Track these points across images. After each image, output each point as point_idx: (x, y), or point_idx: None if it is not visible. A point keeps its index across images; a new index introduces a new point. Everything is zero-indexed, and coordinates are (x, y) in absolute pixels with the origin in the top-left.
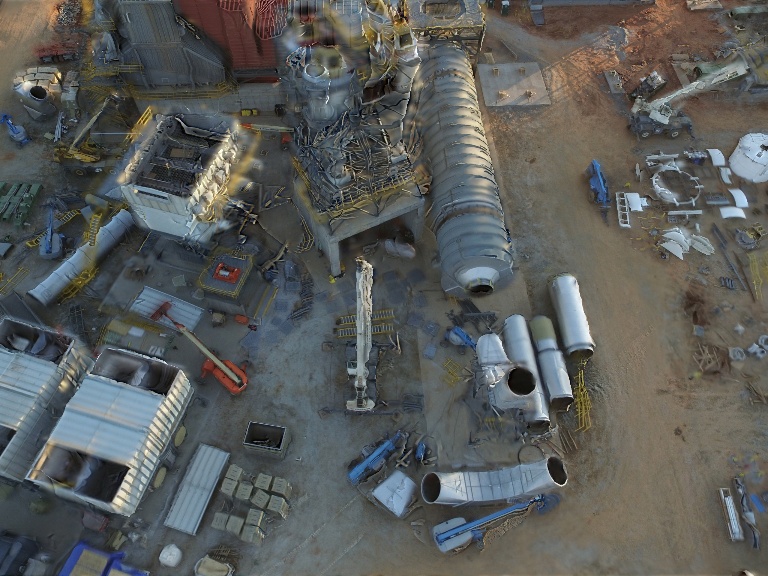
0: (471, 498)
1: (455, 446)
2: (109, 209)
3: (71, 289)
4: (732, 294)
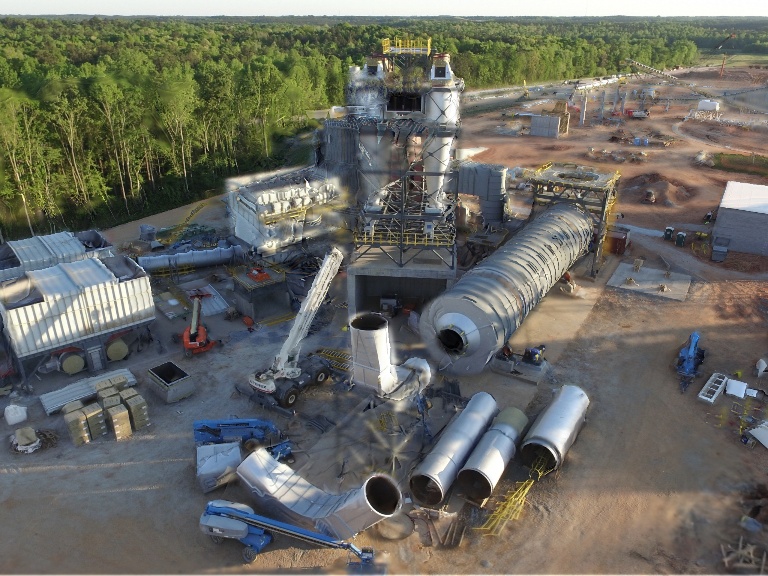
0: (278, 495)
1: (323, 473)
2: None
3: (165, 271)
4: None
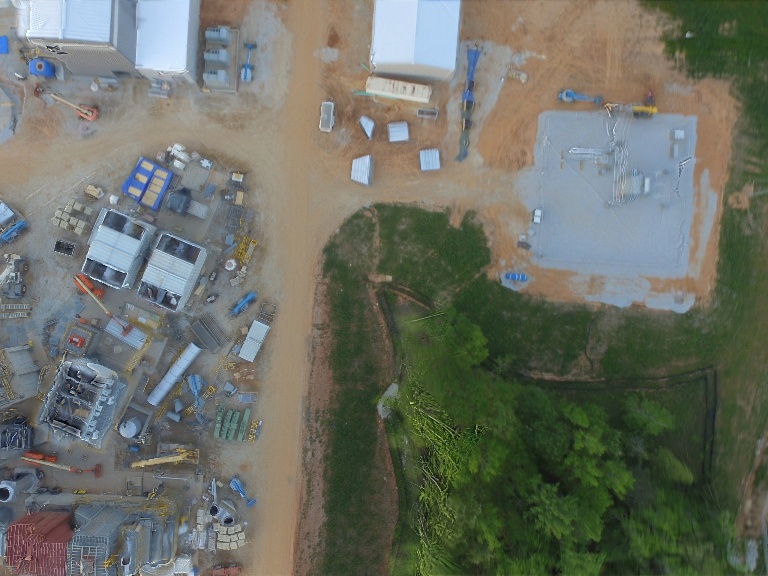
0: None
1: None
2: None
3: None
4: None
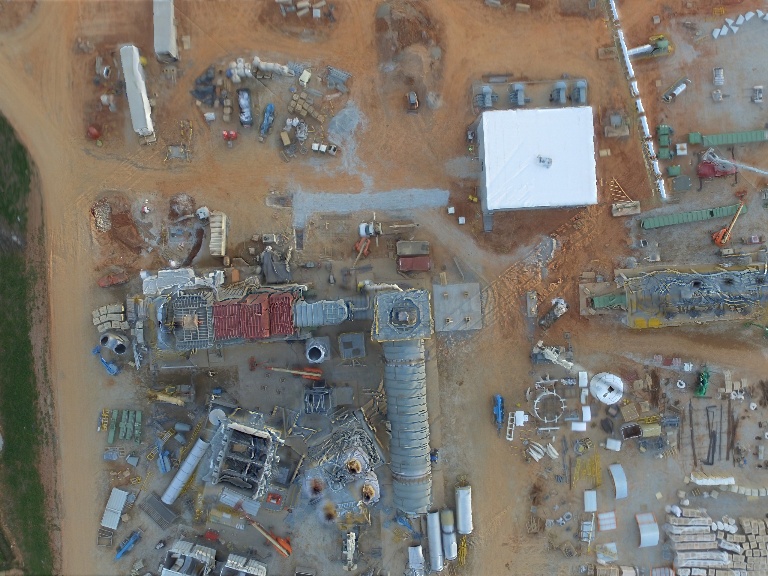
0: None
1: (397, 574)
2: (190, 430)
3: (184, 490)
4: (560, 485)
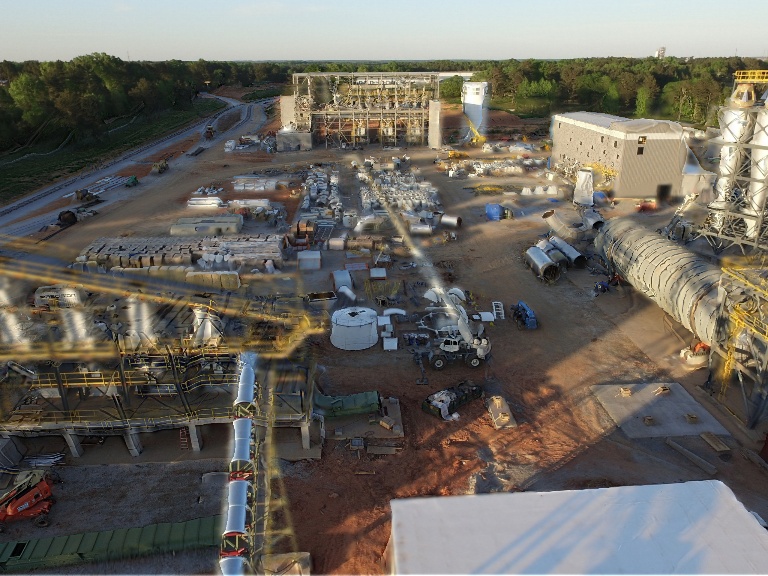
0: None
1: None
2: None
3: None
4: None
